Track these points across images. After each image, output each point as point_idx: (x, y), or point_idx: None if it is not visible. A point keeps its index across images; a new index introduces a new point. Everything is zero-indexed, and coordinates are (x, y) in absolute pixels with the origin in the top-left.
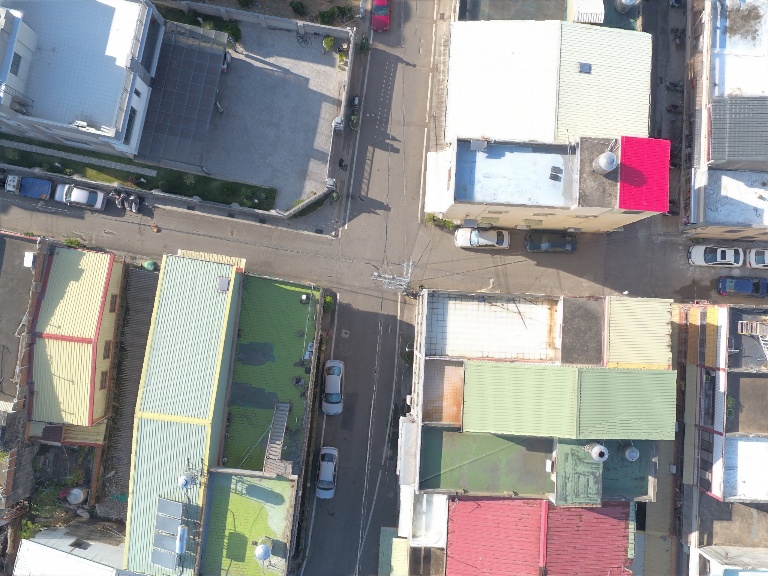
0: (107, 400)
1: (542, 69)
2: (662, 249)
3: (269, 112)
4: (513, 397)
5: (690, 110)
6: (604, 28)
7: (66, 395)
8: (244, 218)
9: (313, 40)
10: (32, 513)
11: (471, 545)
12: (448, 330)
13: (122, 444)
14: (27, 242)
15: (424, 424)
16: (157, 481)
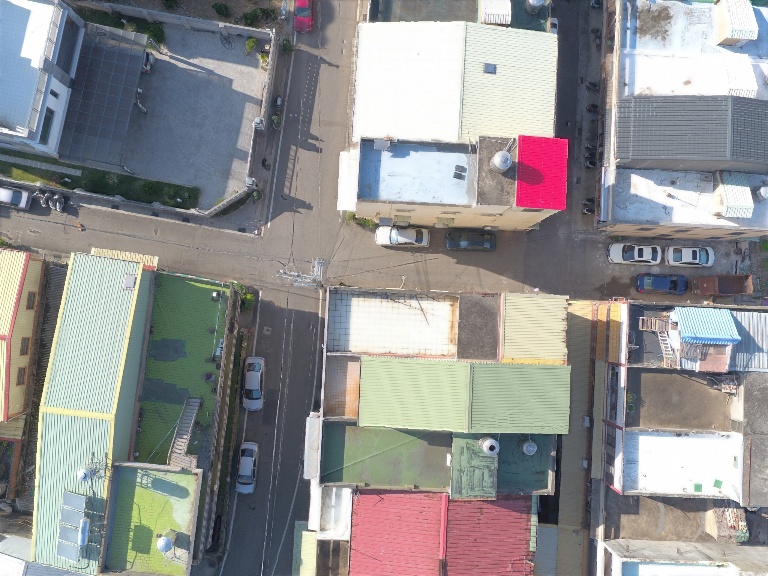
0: (27, 396)
1: (447, 69)
2: (582, 247)
3: (193, 112)
4: (407, 392)
5: (602, 110)
6: (509, 29)
7: None
8: (168, 217)
9: (237, 41)
10: None
11: (374, 538)
12: (351, 326)
13: None
14: None
15: (325, 419)
16: (62, 475)
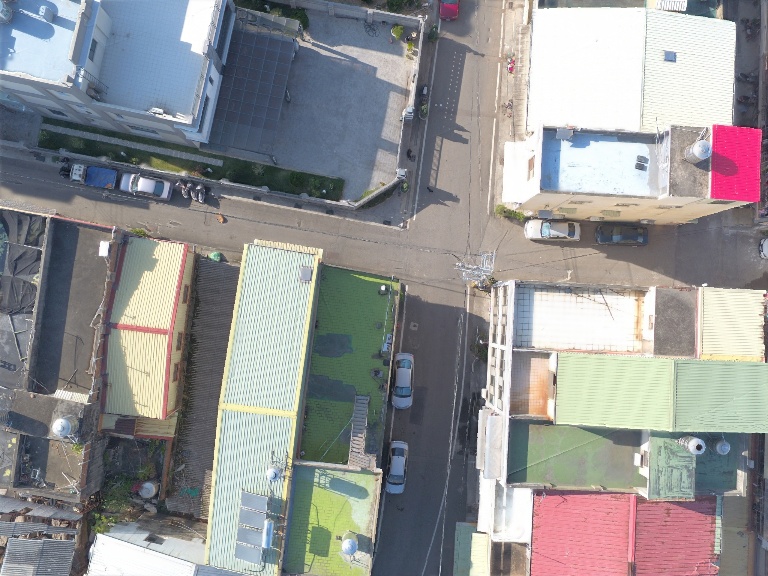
0: (177, 393)
1: (627, 57)
2: (733, 242)
3: (336, 101)
4: (607, 389)
5: (767, 100)
6: (689, 16)
7: (140, 387)
8: (311, 209)
9: (381, 29)
10: (99, 508)
11: (557, 540)
12: (534, 321)
13: (192, 437)
14: (101, 231)
15: (512, 417)
16: (240, 474)
